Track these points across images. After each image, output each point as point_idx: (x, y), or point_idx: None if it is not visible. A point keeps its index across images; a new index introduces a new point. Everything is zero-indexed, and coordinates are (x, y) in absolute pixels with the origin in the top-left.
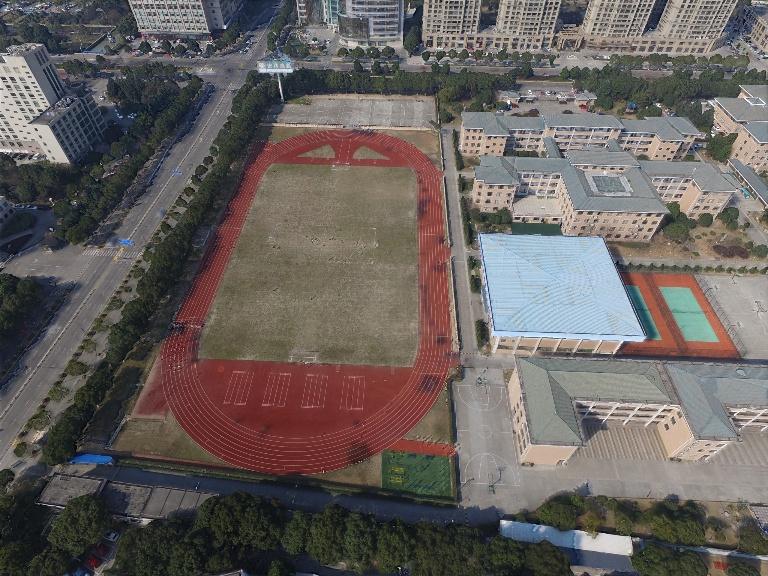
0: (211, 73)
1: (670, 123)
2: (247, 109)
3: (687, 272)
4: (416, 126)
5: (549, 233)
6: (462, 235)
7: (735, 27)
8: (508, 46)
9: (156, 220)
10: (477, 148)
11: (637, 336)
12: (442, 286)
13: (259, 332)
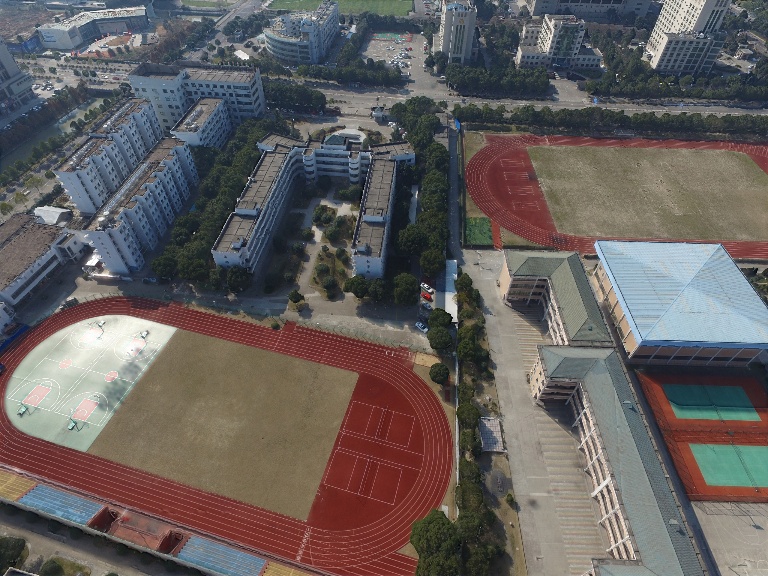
0: None
1: None
2: None
3: None
4: None
5: None
6: None
7: None
8: None
9: (629, 114)
10: None
11: (639, 333)
12: None
13: (555, 165)
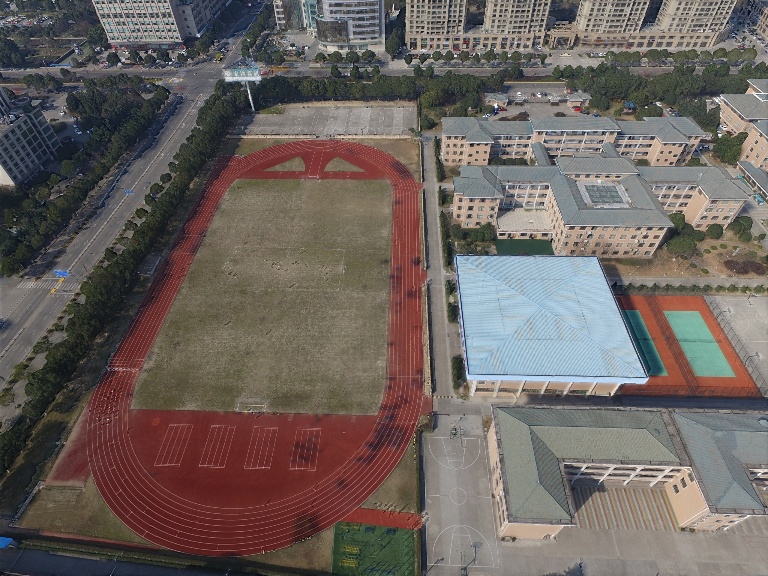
0: (181, 83)
1: (672, 124)
2: (211, 121)
3: (695, 293)
4: (395, 134)
5: (538, 250)
6: (440, 255)
7: (739, 19)
8: (497, 46)
9: (103, 246)
10: (459, 156)
11: (638, 378)
12: (415, 315)
13: (204, 375)
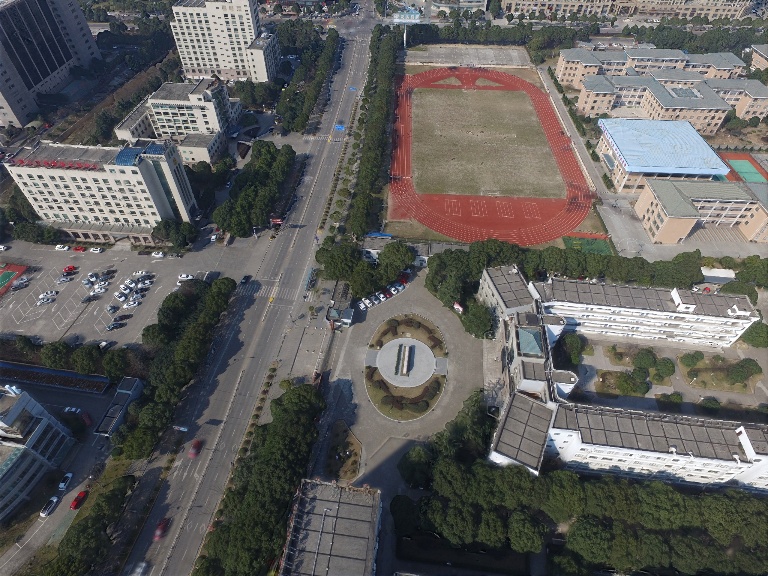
0: (337, 29)
1: (723, 57)
2: (389, 49)
3: (745, 152)
4: None
5: None
6: (576, 131)
7: (758, 0)
8: None
9: (346, 120)
10: (572, 78)
11: (724, 169)
12: (571, 158)
13: (453, 180)
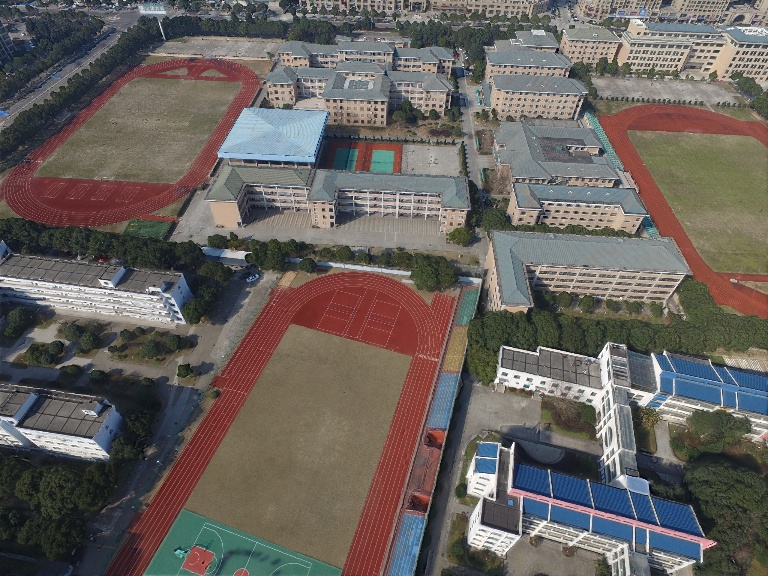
0: (117, 21)
1: (432, 51)
2: (125, 39)
3: (400, 143)
4: None
5: None
6: None
7: None
8: (368, 7)
9: None
10: None
11: (308, 157)
12: None
13: (81, 165)
